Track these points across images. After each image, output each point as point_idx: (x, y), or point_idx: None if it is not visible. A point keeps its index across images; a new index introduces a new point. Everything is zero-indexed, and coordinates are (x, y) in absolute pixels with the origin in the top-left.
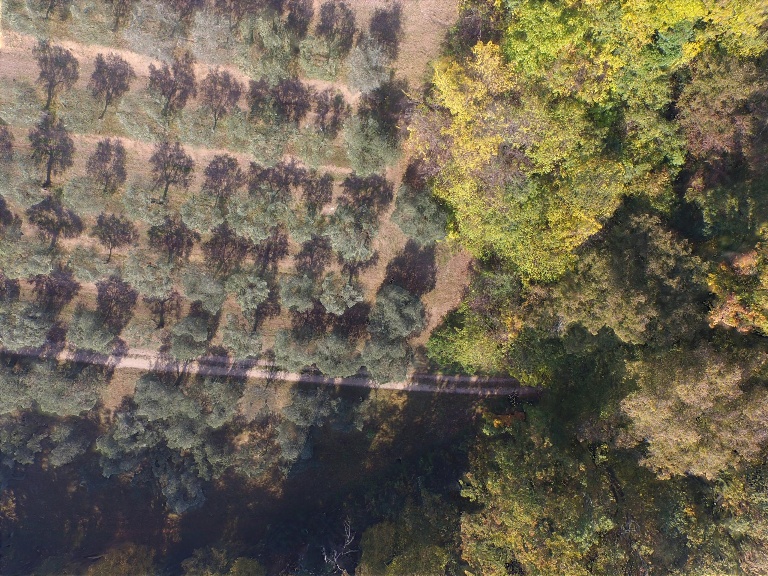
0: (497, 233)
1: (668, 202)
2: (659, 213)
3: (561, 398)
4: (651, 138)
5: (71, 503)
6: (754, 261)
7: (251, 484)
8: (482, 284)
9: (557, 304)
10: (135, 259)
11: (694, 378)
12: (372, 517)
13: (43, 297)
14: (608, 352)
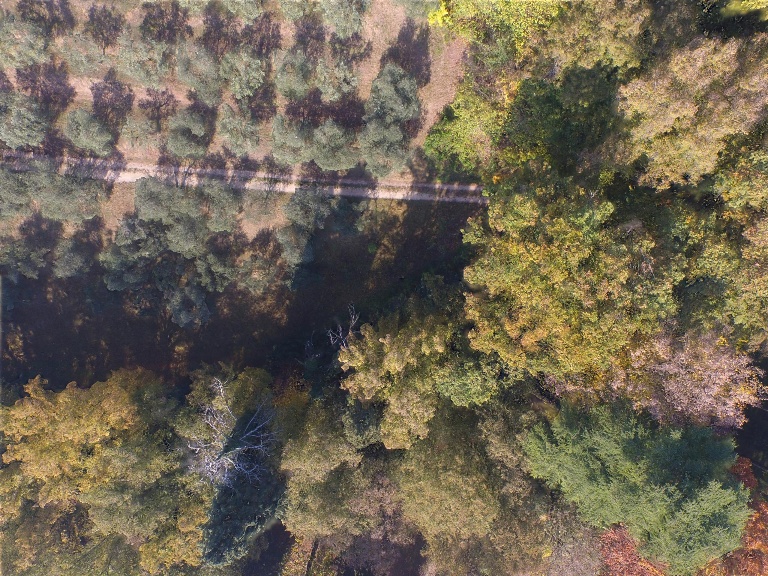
0: None
1: None
2: None
3: None
4: None
5: (78, 338)
6: None
7: (255, 310)
8: None
9: (551, 46)
10: (128, 40)
11: None
12: (377, 330)
13: (39, 105)
14: (605, 106)
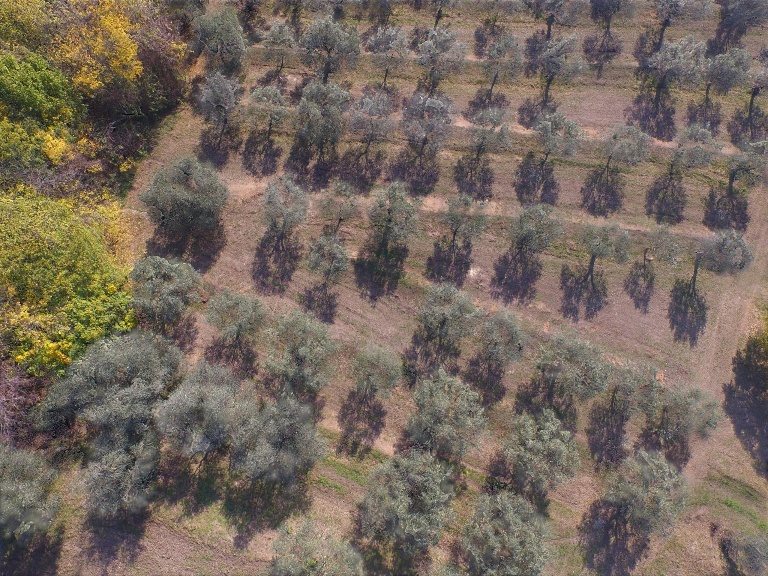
0: None
1: None
2: None
3: None
4: None
5: None
6: None
7: None
8: None
9: None
10: None
11: None
12: None
13: None
14: None
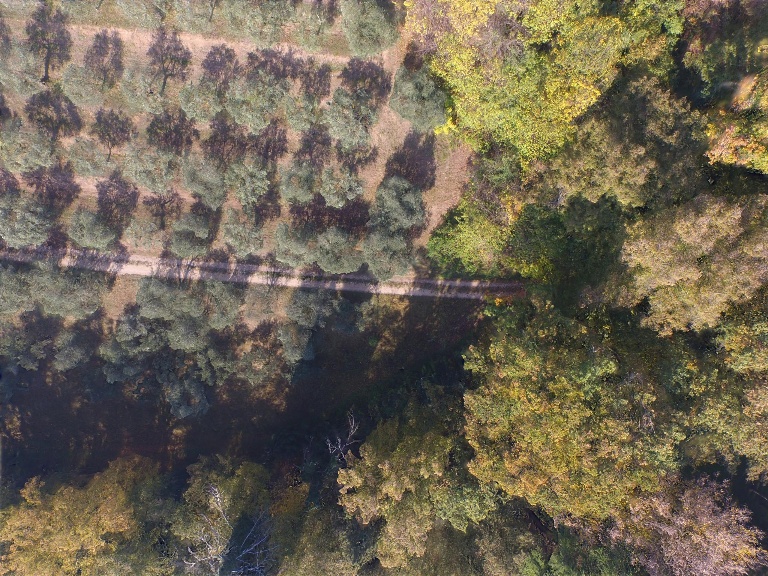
0: (496, 111)
1: (666, 68)
2: (657, 79)
3: (562, 290)
4: (648, 4)
5: (76, 420)
6: (753, 92)
7: (255, 397)
8: (481, 175)
9: (557, 176)
10: (134, 149)
11: (694, 215)
12: (376, 424)
13: (44, 200)
14: (608, 230)
